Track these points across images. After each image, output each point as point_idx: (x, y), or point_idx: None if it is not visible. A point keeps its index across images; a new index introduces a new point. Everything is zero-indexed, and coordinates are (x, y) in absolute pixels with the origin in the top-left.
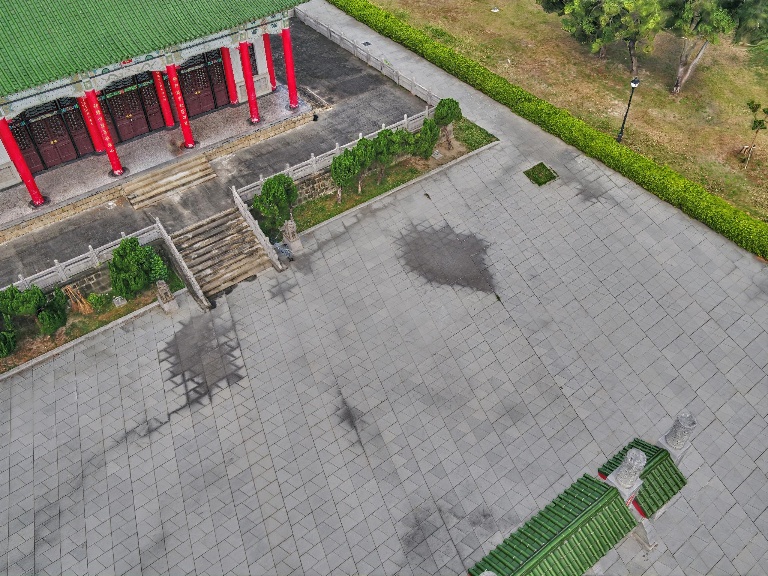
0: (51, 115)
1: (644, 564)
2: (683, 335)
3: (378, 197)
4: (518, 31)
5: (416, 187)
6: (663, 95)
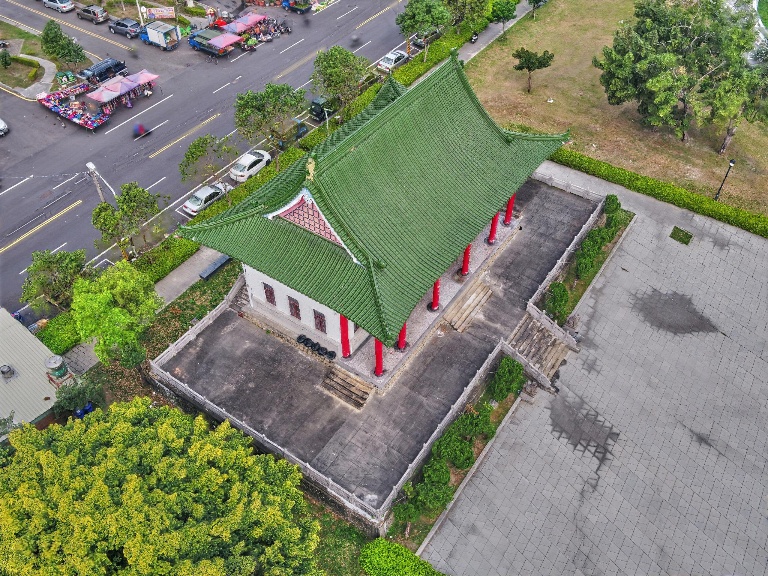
0: None
1: None
2: None
3: (595, 279)
4: (581, 117)
5: (612, 265)
6: (714, 156)
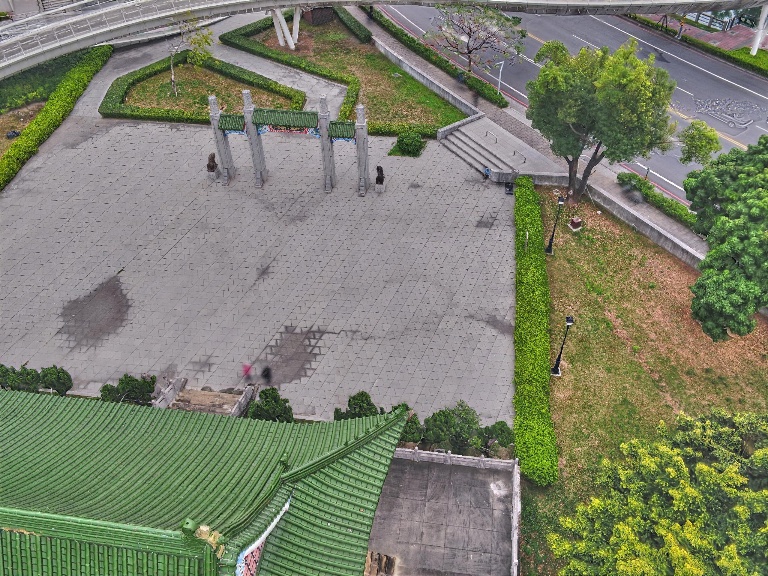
0: None
1: (243, 168)
2: (93, 202)
3: (49, 390)
4: None
5: None
6: None
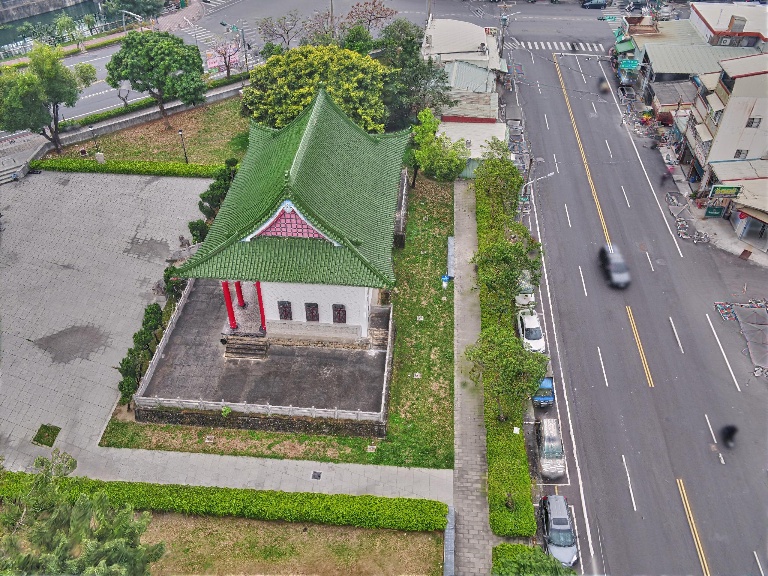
0: None
1: None
2: None
3: None
4: None
5: None
6: None
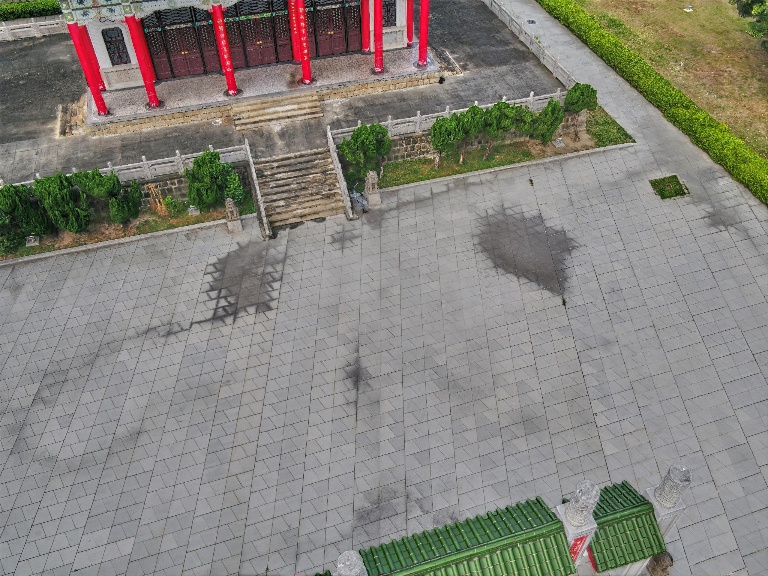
0: (186, 26)
1: None
2: None
3: (478, 172)
4: (706, 35)
5: (523, 171)
6: None
